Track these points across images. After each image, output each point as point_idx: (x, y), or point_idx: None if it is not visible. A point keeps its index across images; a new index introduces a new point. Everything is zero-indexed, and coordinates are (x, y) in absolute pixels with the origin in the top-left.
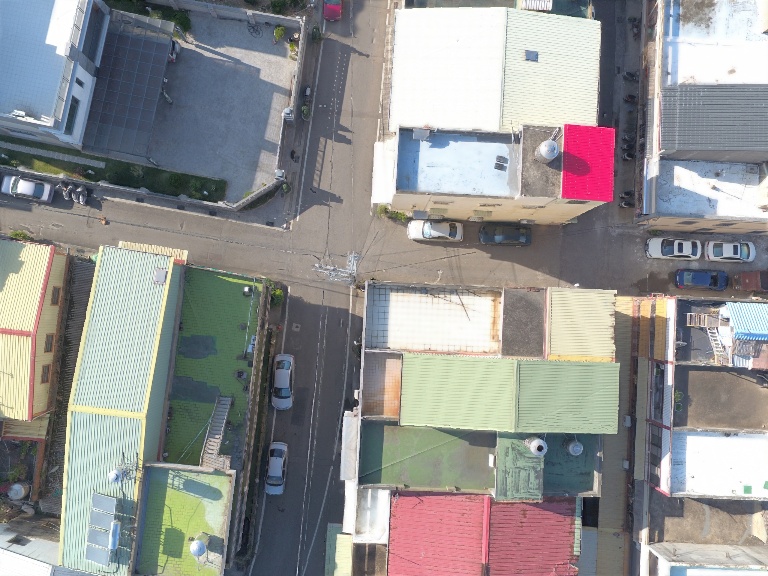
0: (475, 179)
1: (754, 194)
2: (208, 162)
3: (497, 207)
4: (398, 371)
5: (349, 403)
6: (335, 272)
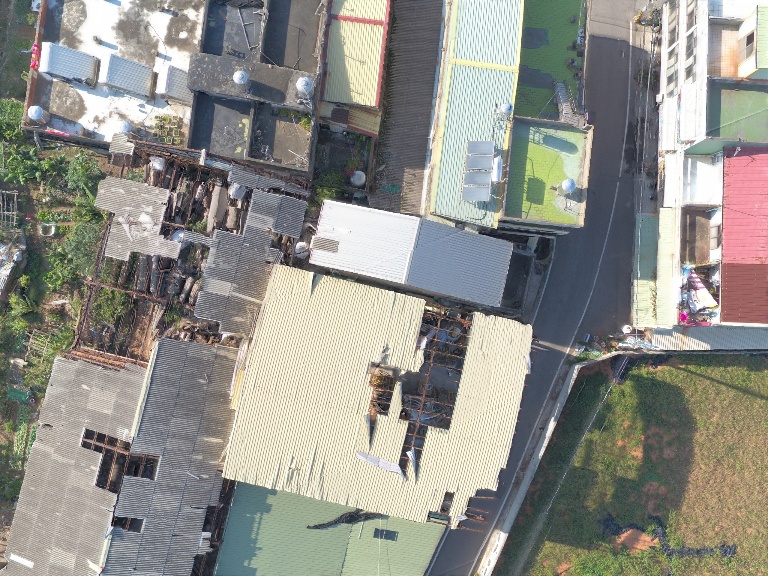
0: None
1: None
2: None
3: None
4: (733, 41)
5: (632, 126)
6: None
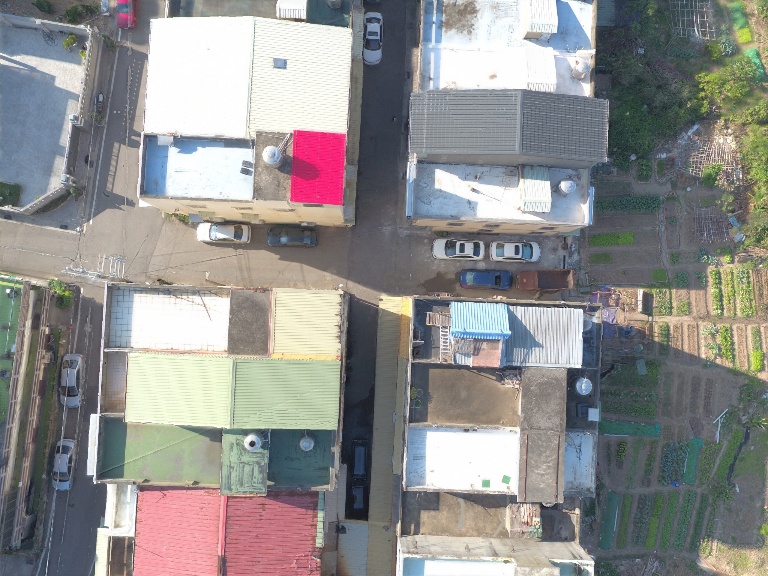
0: (222, 183)
1: (513, 196)
2: (3, 167)
3: (255, 210)
4: None
5: None
6: (84, 274)
